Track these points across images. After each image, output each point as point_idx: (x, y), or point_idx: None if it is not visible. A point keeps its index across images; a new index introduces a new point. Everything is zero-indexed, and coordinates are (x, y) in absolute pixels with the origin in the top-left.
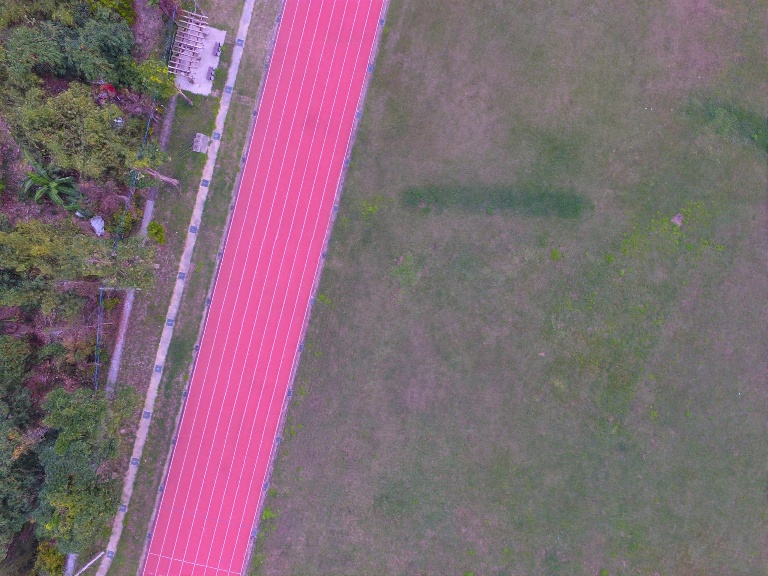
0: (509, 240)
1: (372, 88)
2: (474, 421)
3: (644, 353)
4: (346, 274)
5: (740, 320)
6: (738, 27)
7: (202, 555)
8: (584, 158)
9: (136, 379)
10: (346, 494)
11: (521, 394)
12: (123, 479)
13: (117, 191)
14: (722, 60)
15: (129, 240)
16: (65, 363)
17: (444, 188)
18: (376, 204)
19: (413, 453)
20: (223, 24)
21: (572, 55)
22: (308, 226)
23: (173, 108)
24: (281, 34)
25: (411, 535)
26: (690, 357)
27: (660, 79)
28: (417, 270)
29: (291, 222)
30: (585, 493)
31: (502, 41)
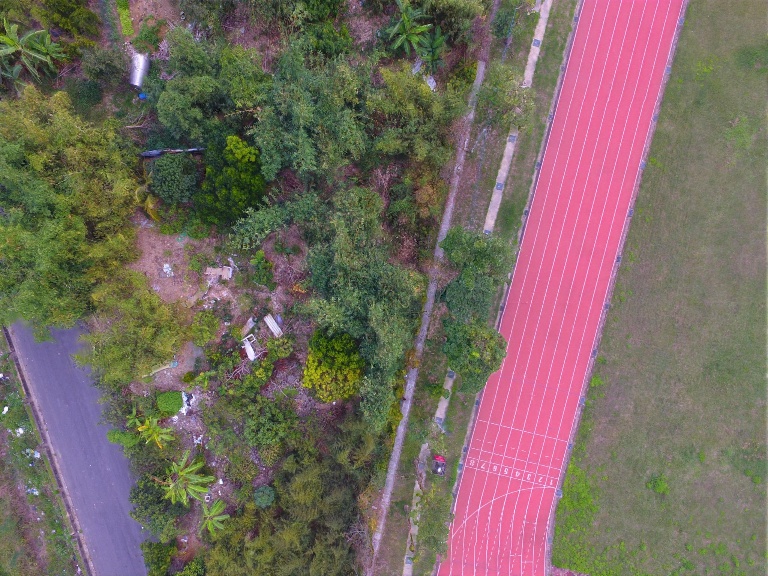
0: None
1: None
2: None
3: None
4: (679, 137)
5: None
6: None
7: (530, 422)
8: None
9: None
10: (676, 362)
11: None
12: None
13: None
14: None
15: None
16: (409, 221)
17: None
18: (711, 64)
19: (744, 320)
20: None
21: None
22: (640, 88)
23: None
24: None
25: (741, 403)
26: None
27: None
28: (752, 132)
29: (623, 83)
30: None
31: None
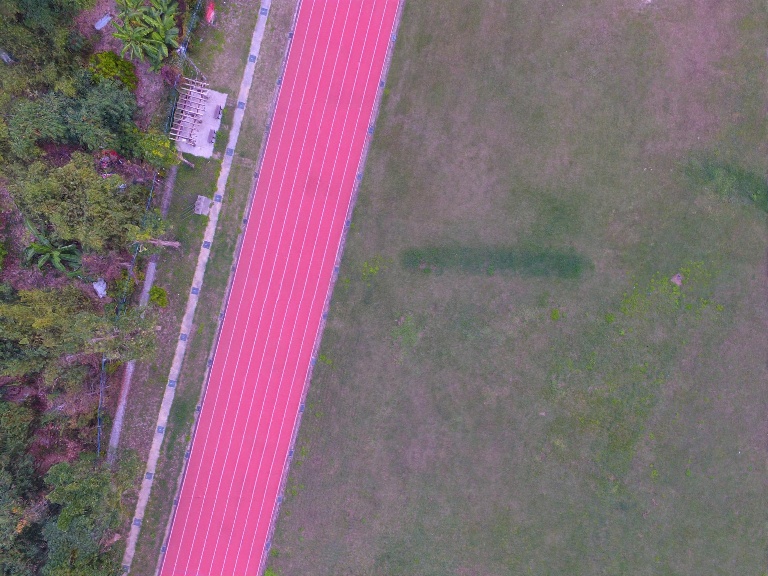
0: (509, 300)
1: (373, 150)
2: (475, 481)
3: (644, 412)
4: (347, 335)
5: (740, 379)
6: (737, 88)
7: None
8: (584, 218)
9: (138, 440)
10: (348, 554)
11: (522, 454)
12: (125, 540)
13: (119, 259)
14: (721, 121)
15: (131, 311)
16: (68, 427)
17: (444, 249)
18: (377, 265)
19: (414, 513)
20: (224, 87)
21: (572, 116)
22: (309, 287)
23: (175, 171)
24: (282, 96)
25: None
26: (690, 416)
27: (659, 140)
28: (418, 331)
29: (292, 283)
30: (586, 552)
31: (502, 103)
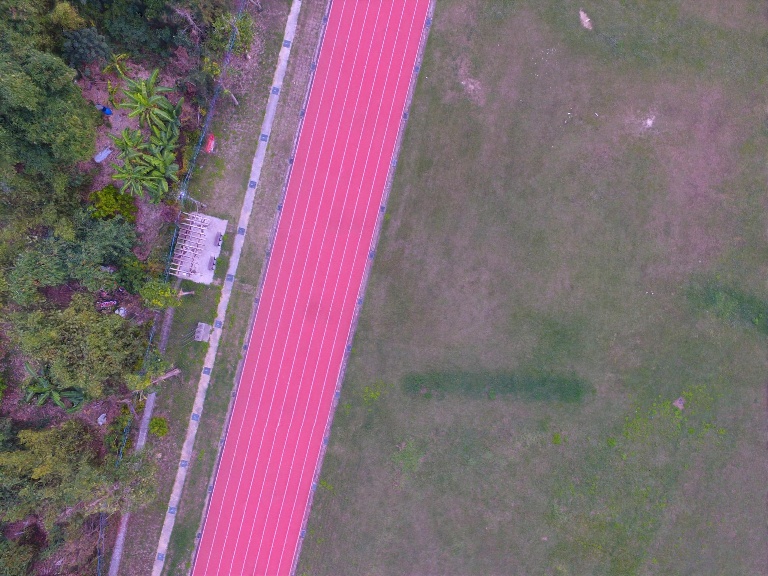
0: (511, 425)
1: (373, 274)
2: None
3: (647, 537)
4: (348, 460)
5: (743, 503)
6: (738, 212)
7: None
8: (585, 342)
9: (138, 568)
10: None
11: None
12: None
13: (119, 397)
14: (722, 244)
15: (131, 456)
16: None
17: (446, 374)
18: (378, 390)
19: None
20: (224, 213)
21: (573, 240)
22: (310, 412)
23: None
24: (282, 222)
25: None
26: (693, 540)
27: (661, 263)
28: (419, 456)
29: (293, 409)
30: None
31: (503, 227)
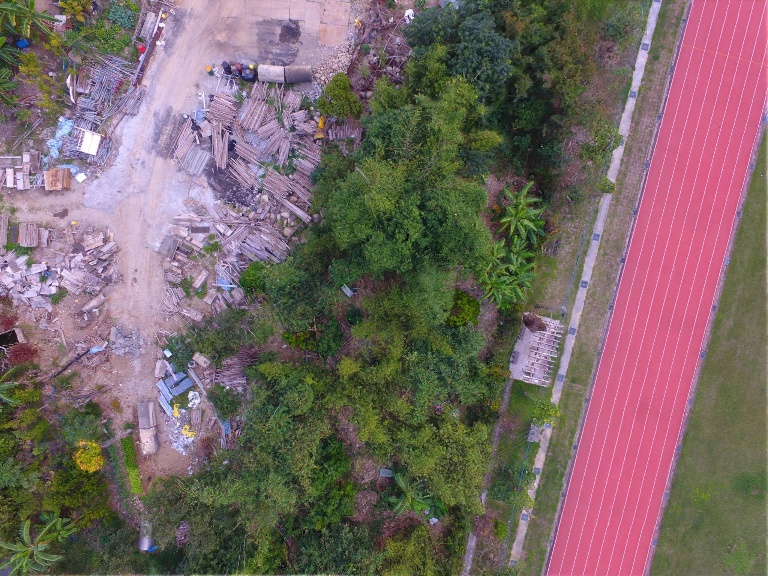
0: None
1: (704, 374)
2: None
3: None
4: (678, 561)
5: None
6: None
7: None
8: None
9: None
10: None
11: None
12: None
13: None
14: None
15: (510, 572)
16: None
17: None
18: (708, 491)
19: None
20: (556, 313)
21: None
22: (639, 513)
23: (507, 398)
24: (614, 322)
25: None
26: None
27: None
28: (751, 558)
29: (622, 509)
30: None
31: None
